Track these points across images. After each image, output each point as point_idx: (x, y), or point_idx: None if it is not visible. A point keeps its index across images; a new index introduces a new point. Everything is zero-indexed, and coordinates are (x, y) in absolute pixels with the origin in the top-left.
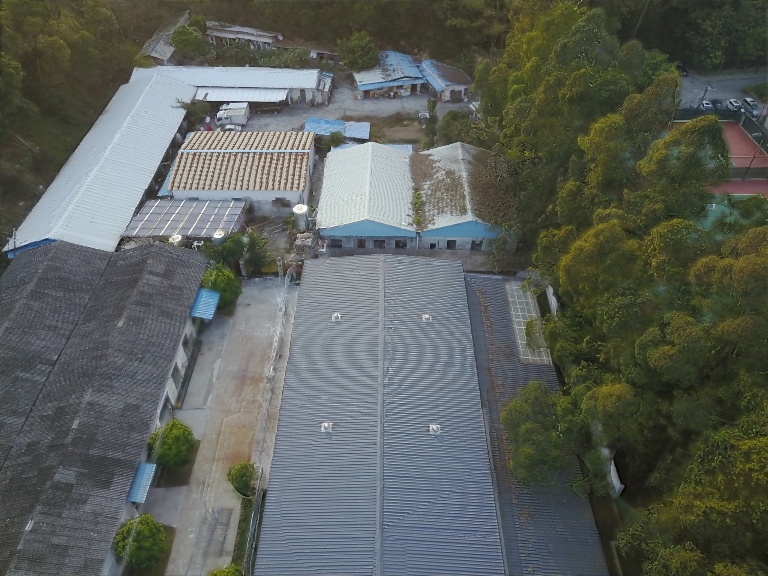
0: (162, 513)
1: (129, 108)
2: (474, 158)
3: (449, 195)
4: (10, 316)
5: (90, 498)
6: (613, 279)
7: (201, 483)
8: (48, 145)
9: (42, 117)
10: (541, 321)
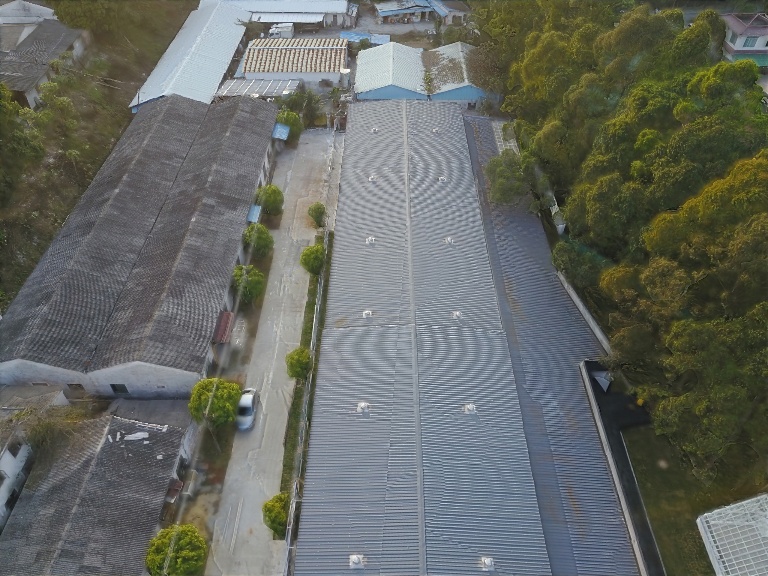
0: None
1: (203, 23)
2: (470, 52)
3: (451, 73)
4: (151, 131)
5: (225, 213)
6: (552, 66)
7: (287, 228)
8: (144, 48)
9: (137, 29)
10: (513, 123)
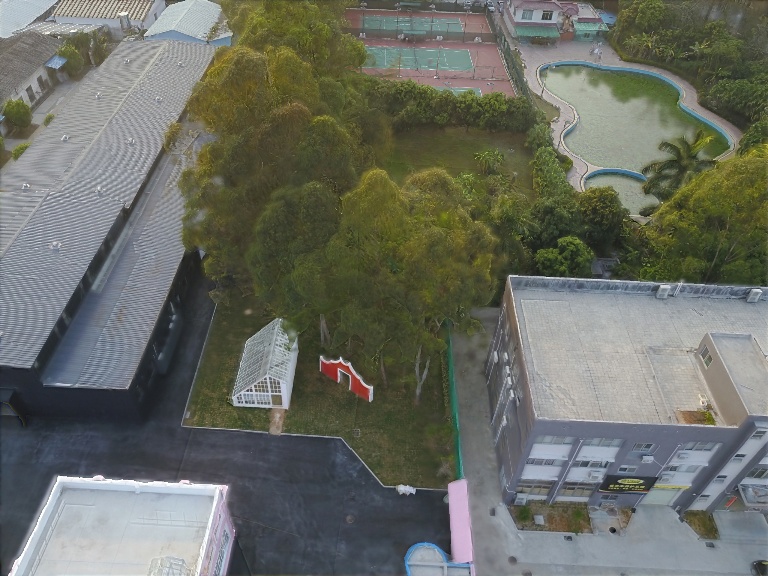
0: (8, 147)
1: None
2: None
3: None
4: None
5: None
6: (235, 2)
7: None
8: None
9: None
10: None
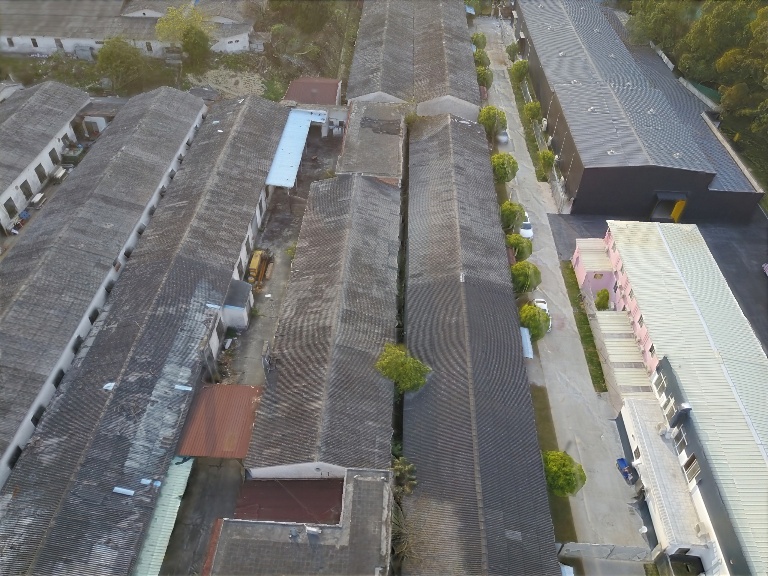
0: None
1: None
2: None
3: None
4: (388, 1)
5: None
6: None
7: None
8: None
9: None
10: None
